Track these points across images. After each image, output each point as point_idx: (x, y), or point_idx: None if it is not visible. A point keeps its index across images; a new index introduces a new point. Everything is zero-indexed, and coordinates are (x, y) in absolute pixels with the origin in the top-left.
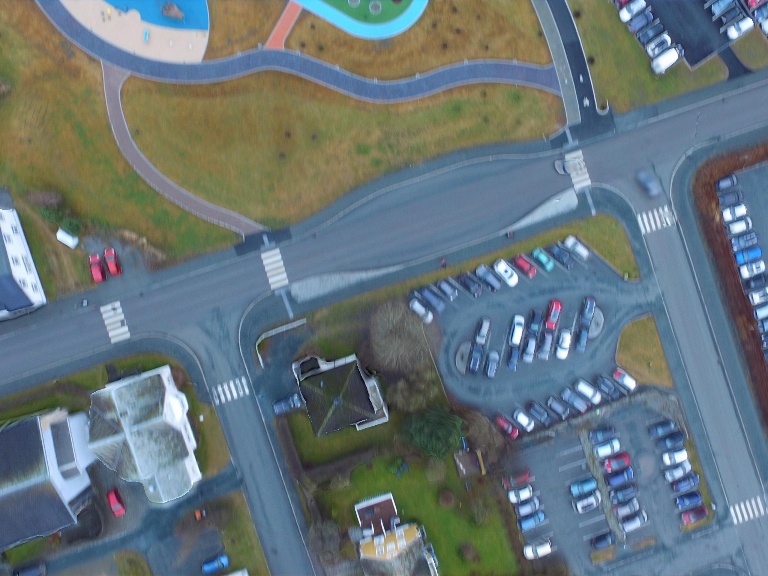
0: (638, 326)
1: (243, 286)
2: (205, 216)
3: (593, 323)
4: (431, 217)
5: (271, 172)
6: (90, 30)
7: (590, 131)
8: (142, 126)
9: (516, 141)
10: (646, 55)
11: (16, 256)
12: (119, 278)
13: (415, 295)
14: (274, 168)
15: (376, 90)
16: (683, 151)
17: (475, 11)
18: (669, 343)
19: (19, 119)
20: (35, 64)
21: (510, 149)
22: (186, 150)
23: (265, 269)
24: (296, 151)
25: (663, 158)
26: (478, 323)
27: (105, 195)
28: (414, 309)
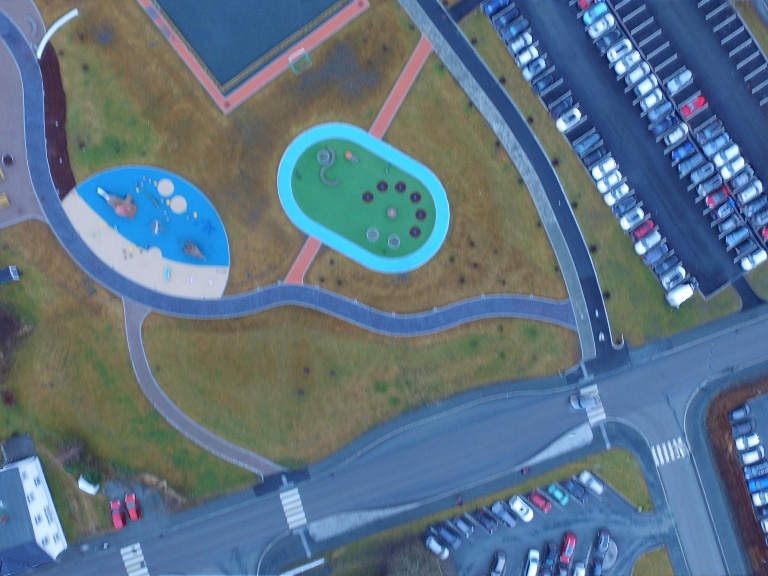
0: (651, 558)
1: (262, 526)
2: (224, 456)
3: (607, 555)
4: (448, 454)
5: (290, 410)
6: (112, 267)
7: (605, 366)
8: (162, 362)
9: (532, 378)
10: (661, 287)
11: (39, 513)
12: (139, 522)
13: (431, 531)
14: (293, 406)
15: (394, 324)
16: (697, 383)
17: (492, 246)
18: (682, 574)
19: (41, 362)
20: (57, 302)
21: (526, 386)
22: (206, 387)
23: (283, 509)
24: (315, 388)
25: (677, 390)
26: (493, 558)
27: (126, 436)
28: (431, 548)
